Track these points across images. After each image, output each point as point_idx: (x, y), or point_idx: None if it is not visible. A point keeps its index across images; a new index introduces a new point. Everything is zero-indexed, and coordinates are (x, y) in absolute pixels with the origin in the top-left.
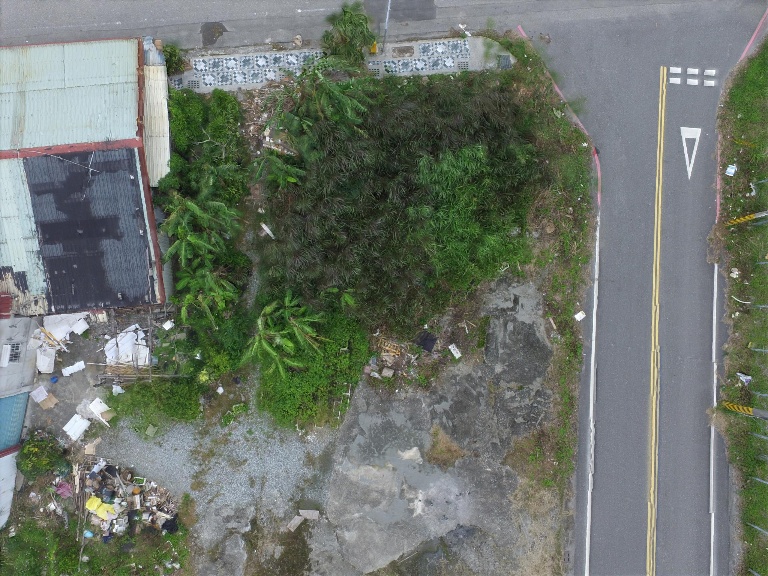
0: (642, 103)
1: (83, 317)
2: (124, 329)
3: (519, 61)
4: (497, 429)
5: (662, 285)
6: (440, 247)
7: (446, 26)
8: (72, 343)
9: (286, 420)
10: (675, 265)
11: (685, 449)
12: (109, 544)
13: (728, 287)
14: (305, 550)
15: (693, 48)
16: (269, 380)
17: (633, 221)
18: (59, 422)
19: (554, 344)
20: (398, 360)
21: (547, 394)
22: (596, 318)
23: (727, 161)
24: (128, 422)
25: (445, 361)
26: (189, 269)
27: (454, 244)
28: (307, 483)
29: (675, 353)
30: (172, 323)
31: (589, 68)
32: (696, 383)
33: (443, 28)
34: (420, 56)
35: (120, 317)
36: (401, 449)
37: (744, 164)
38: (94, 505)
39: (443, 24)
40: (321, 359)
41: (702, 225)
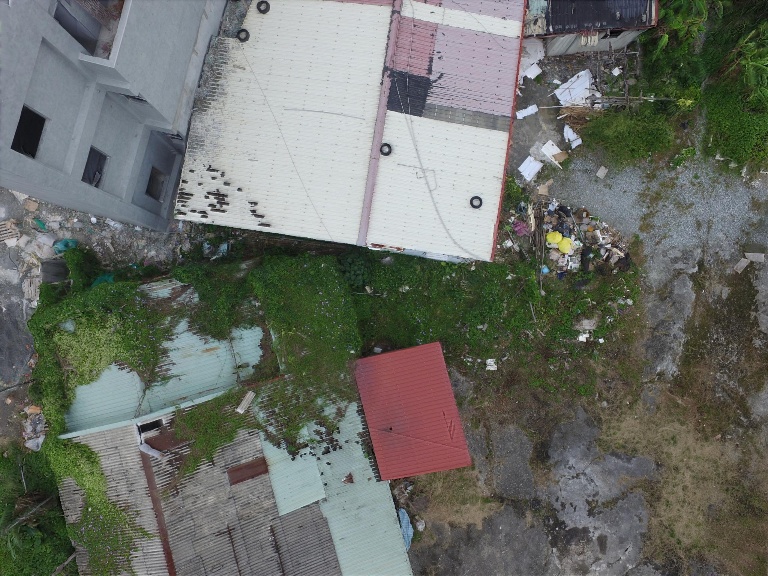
0: None
1: (536, 62)
2: (575, 74)
3: None
4: None
5: None
6: None
7: None
8: (525, 87)
9: (743, 159)
10: None
11: None
12: (563, 281)
13: None
14: (751, 292)
15: None
16: (724, 121)
17: None
18: (513, 163)
19: None
20: None
21: None
22: None
23: None
24: (579, 165)
25: None
26: (659, 5)
27: None
28: (752, 227)
29: None
30: (620, 70)
31: None
32: None
33: None
34: None
35: (570, 63)
36: None
37: None
38: (559, 237)
39: None
40: None
41: None
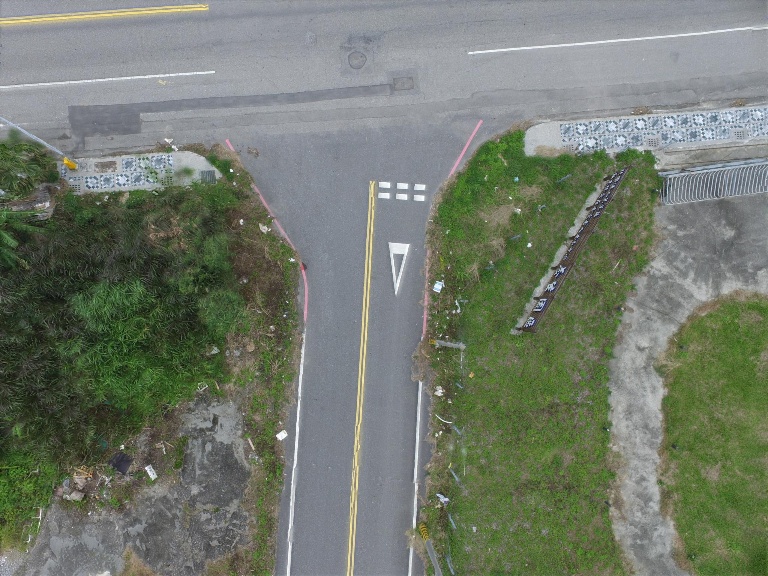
0: (350, 218)
1: None
2: None
3: (224, 176)
4: (191, 552)
5: (365, 404)
6: (101, 381)
7: (152, 140)
8: None
9: None
10: (379, 383)
11: (383, 572)
12: None
13: (432, 405)
14: None
15: (403, 162)
16: None
17: (338, 338)
18: None
19: (252, 465)
20: (90, 483)
21: (243, 516)
22: (298, 437)
23: (435, 277)
24: None
25: (140, 483)
26: None
27: (115, 378)
28: None
29: (376, 473)
30: None
31: (297, 183)
32: (396, 504)
33: (149, 142)
34: (123, 171)
35: None
36: (92, 574)
37: (452, 280)
38: None
39: (149, 138)
40: (4, 485)
41: (408, 342)
